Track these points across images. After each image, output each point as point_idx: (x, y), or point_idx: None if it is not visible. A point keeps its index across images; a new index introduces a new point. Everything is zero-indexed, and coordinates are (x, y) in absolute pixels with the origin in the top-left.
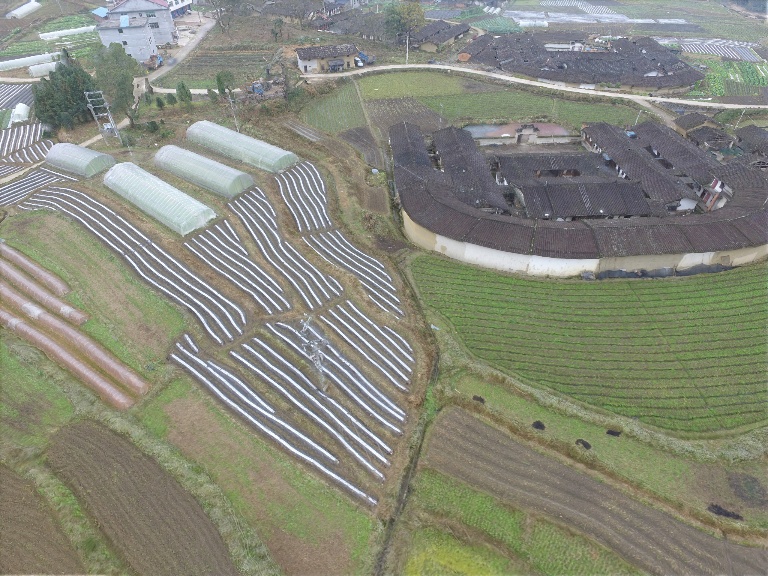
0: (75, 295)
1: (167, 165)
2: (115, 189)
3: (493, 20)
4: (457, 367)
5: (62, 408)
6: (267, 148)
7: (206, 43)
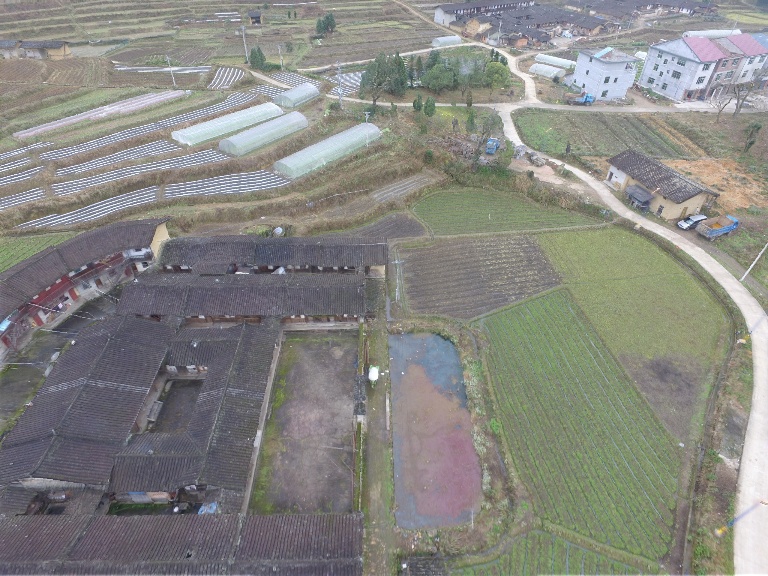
0: None
1: None
2: None
3: None
4: None
5: None
6: (301, 154)
7: (686, 114)
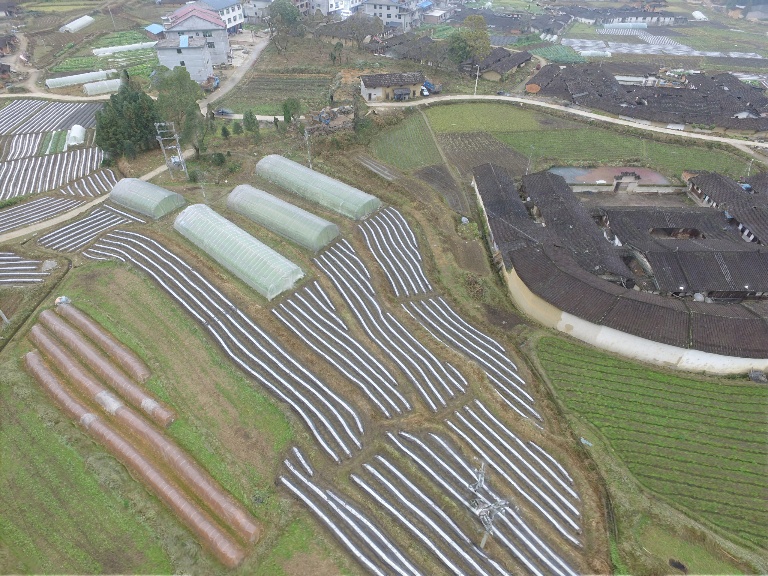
0: (156, 382)
1: (242, 208)
2: (187, 236)
3: (552, 48)
4: (637, 511)
5: (156, 564)
6: (348, 191)
7: (262, 65)
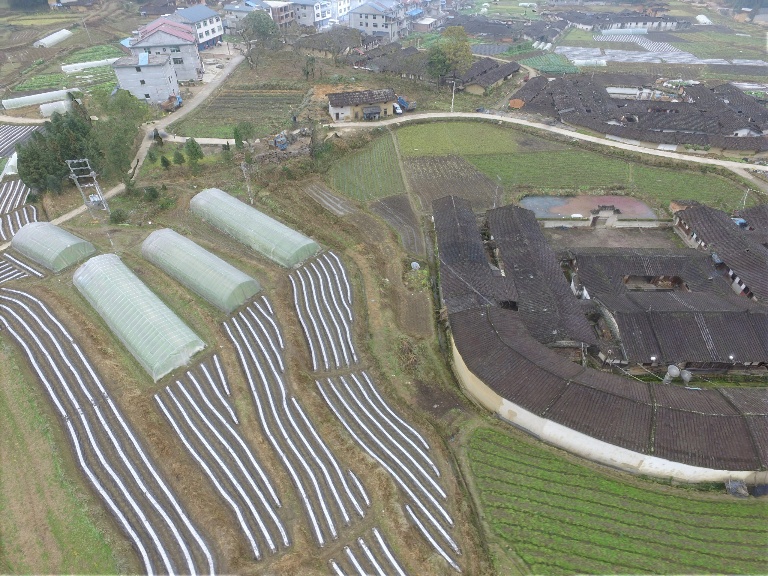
0: None
1: (155, 258)
2: (84, 294)
3: (544, 57)
4: None
5: None
6: (282, 234)
7: (232, 80)
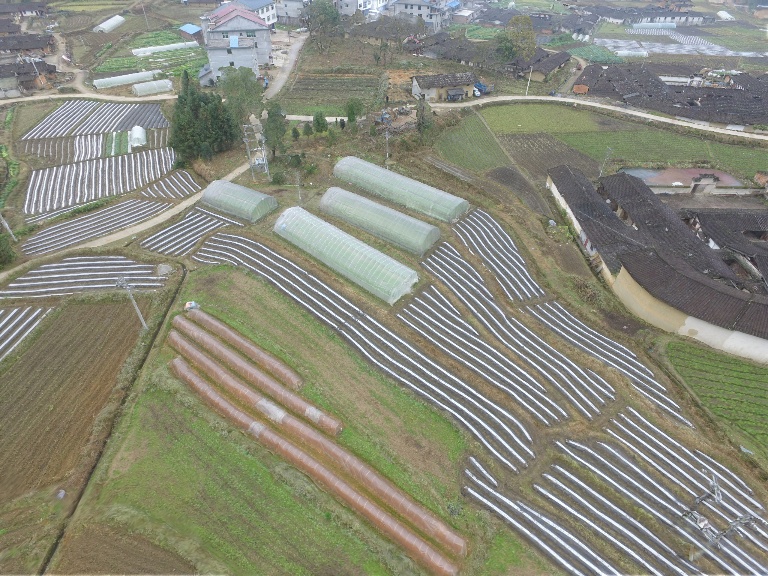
0: (312, 389)
1: (337, 211)
2: (290, 239)
3: (586, 48)
4: None
5: None
6: (436, 193)
7: (305, 65)
